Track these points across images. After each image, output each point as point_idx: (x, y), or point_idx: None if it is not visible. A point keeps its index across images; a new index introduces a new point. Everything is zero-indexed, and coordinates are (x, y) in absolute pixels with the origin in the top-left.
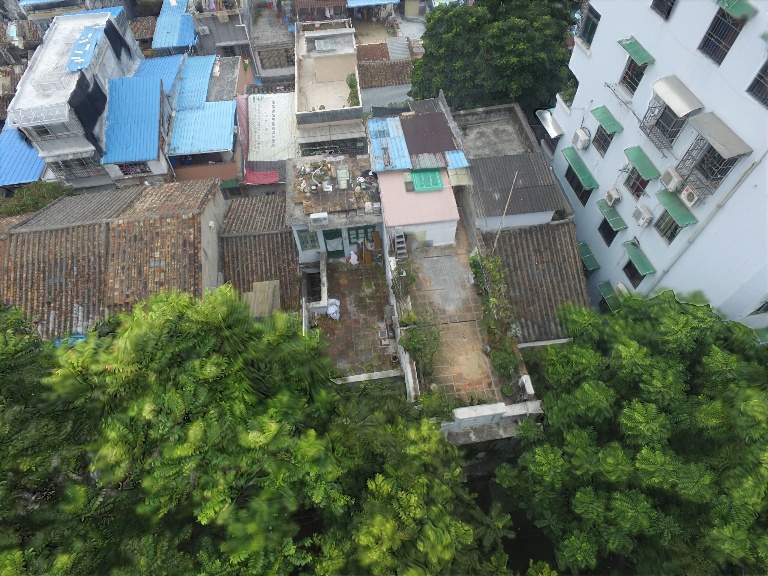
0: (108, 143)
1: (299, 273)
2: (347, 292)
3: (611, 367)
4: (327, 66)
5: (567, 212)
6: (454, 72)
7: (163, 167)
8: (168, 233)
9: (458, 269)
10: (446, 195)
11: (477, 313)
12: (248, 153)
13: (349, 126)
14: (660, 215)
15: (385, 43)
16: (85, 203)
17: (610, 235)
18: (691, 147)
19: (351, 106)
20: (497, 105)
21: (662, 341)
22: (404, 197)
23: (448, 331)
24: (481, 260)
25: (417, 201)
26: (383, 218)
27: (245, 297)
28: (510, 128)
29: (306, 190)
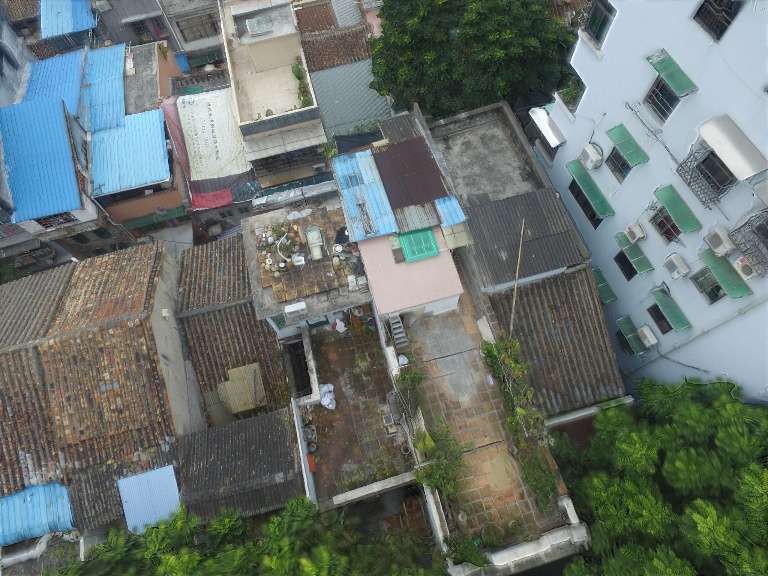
0: (15, 195)
1: (279, 346)
2: (339, 370)
3: (681, 530)
4: (266, 52)
5: (583, 256)
6: (426, 65)
7: (91, 213)
8: (114, 347)
9: (466, 344)
10: (444, 261)
11: (496, 401)
12: (190, 171)
13: (305, 130)
14: (699, 270)
15: (330, 3)
16: (2, 303)
17: (629, 268)
18: (753, 218)
19: (304, 107)
20: (483, 107)
21: (741, 498)
22: (394, 271)
23: (466, 430)
24: (498, 352)
25: (410, 275)
26: (372, 297)
27: (222, 389)
28: (500, 133)
29: (273, 269)
